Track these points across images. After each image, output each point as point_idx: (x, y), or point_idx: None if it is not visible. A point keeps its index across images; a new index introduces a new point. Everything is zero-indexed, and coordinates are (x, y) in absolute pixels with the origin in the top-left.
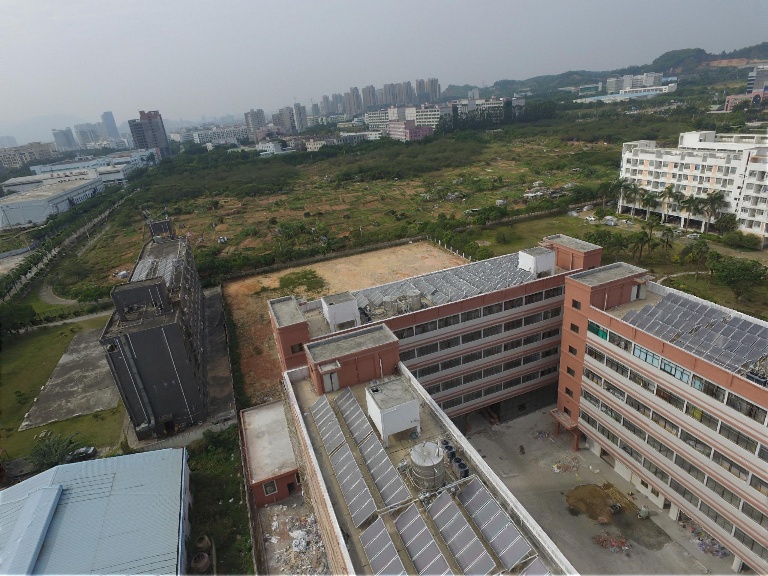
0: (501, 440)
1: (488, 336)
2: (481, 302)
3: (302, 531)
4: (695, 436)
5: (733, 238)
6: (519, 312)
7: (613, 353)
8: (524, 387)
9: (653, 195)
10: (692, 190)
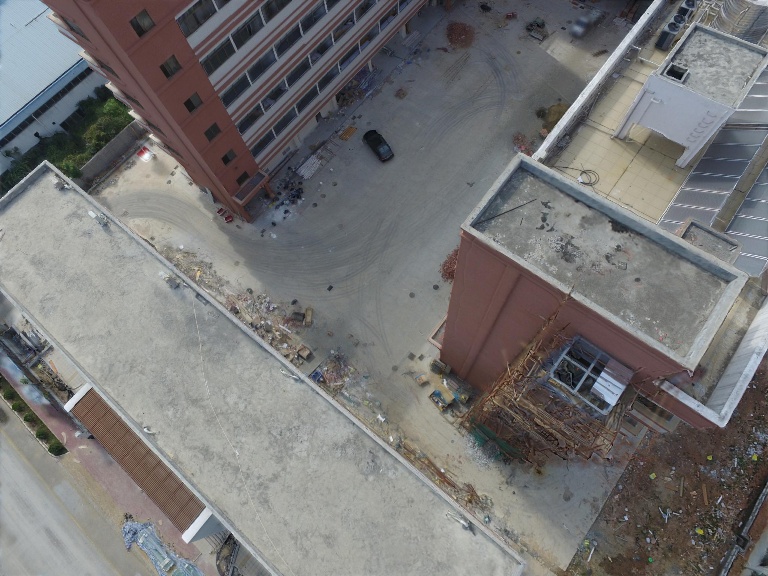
0: (602, 32)
1: None
2: None
3: None
4: None
5: None
6: None
7: None
8: None
9: None
10: None
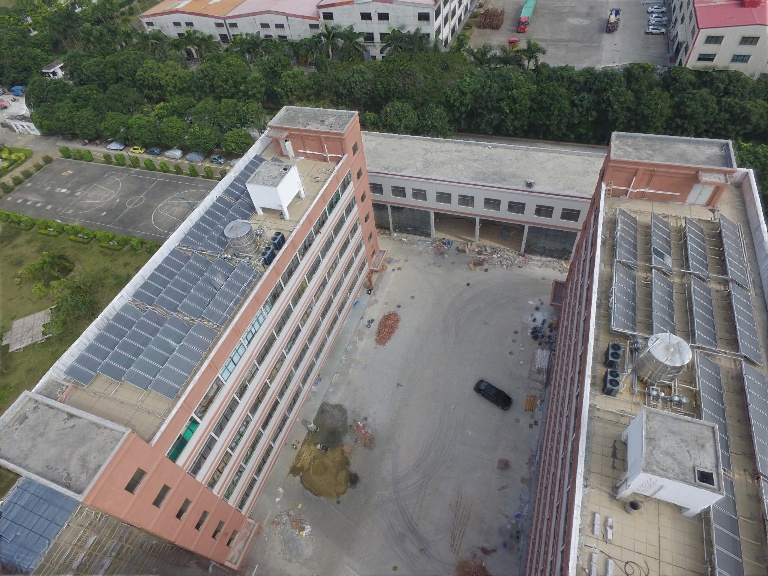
0: None
1: None
2: None
3: None
4: None
5: None
6: None
7: None
8: None
9: None
10: None
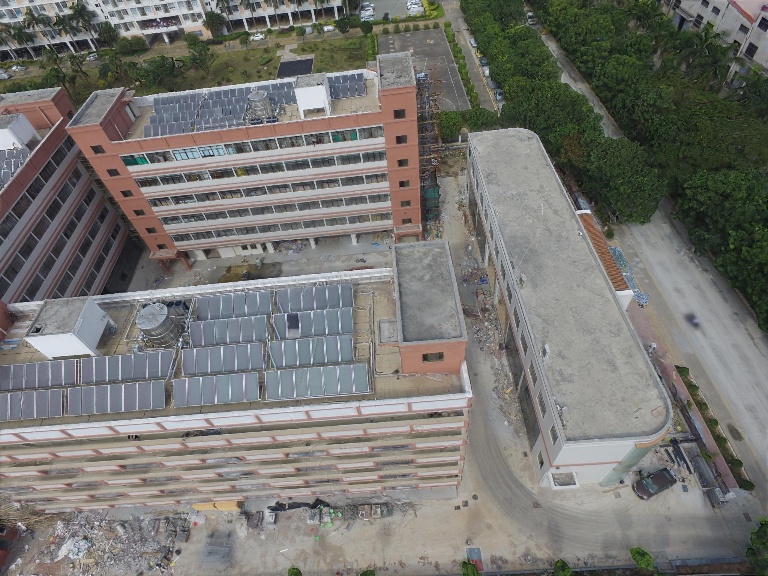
0: None
1: (42, 235)
2: (4, 205)
3: (66, 543)
4: (252, 187)
5: (124, 45)
6: (48, 193)
7: (161, 170)
8: (111, 259)
9: (18, 27)
10: (52, 8)
